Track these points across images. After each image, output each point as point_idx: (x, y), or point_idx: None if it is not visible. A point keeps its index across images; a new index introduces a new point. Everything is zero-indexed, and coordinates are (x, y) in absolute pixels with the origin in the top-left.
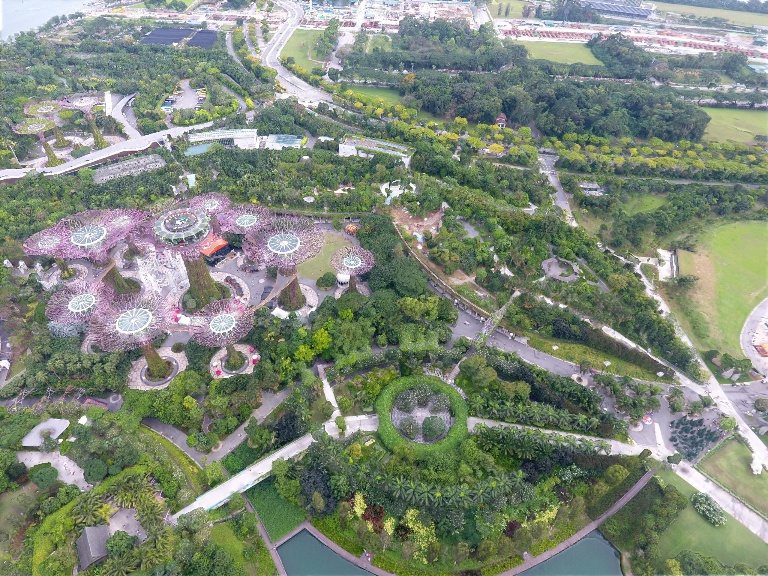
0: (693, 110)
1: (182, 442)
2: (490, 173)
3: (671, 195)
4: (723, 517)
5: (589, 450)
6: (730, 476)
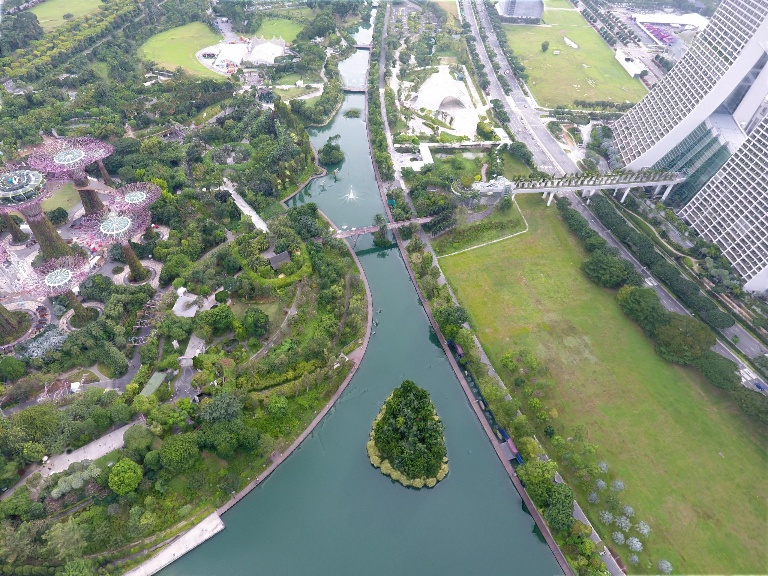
0: (22, 14)
1: None
2: (13, 102)
3: (99, 57)
4: (303, 99)
5: (269, 113)
6: (287, 95)
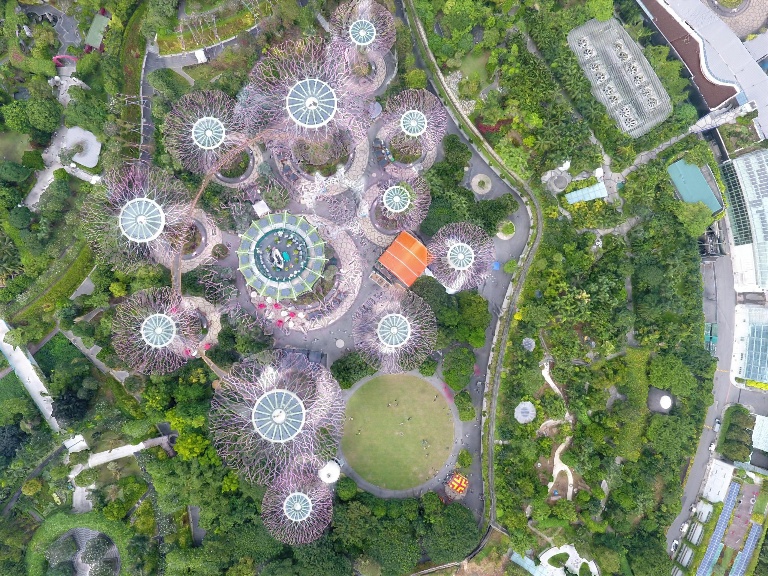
0: None
1: (87, 286)
2: None
3: None
4: None
5: None
6: None
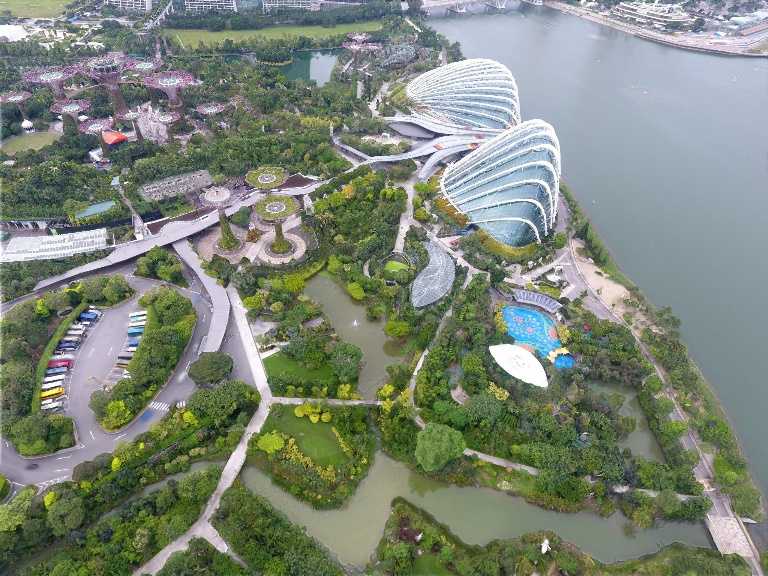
0: None
1: None
2: None
3: None
4: None
5: None
6: None
